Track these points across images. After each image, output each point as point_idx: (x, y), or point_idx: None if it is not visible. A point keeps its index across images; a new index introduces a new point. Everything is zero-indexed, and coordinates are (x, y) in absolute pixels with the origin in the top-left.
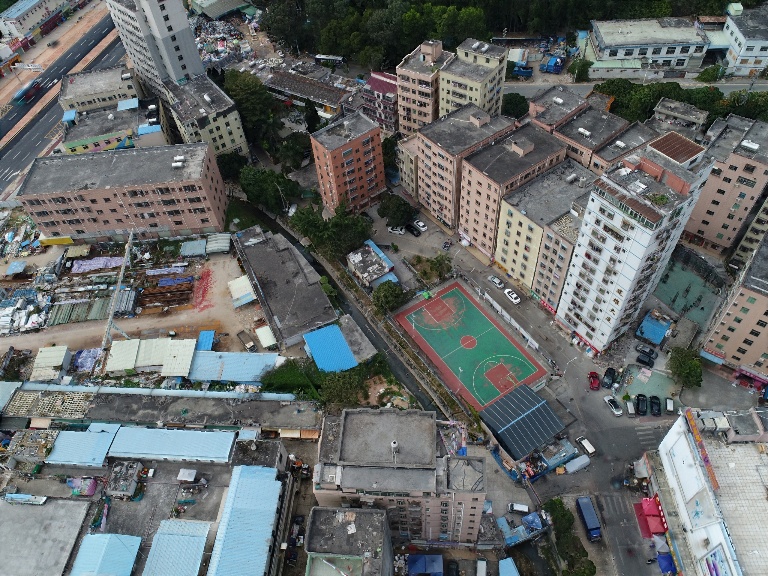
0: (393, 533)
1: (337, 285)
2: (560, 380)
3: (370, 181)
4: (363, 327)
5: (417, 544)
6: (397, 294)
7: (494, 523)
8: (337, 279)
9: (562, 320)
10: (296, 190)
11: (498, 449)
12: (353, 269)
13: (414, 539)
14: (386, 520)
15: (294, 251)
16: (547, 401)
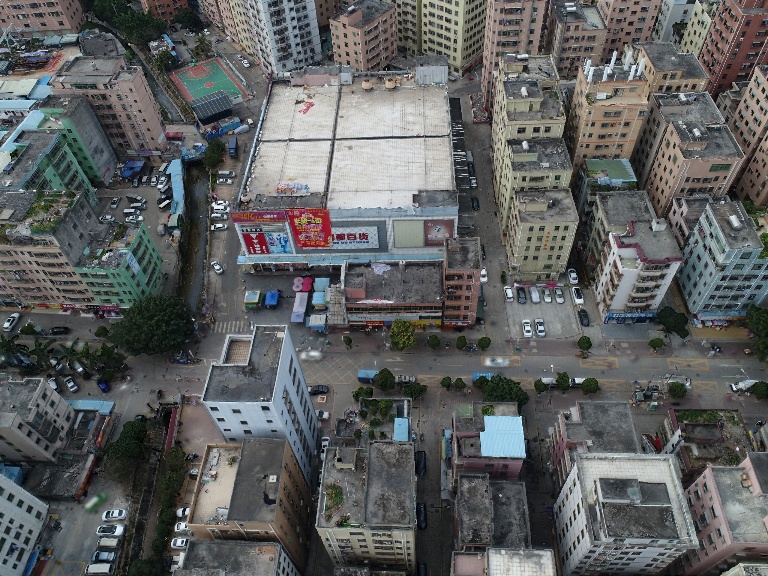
0: (115, 144)
1: (143, 64)
2: (254, 99)
3: (174, 2)
4: (151, 83)
5: (131, 155)
6: (169, 57)
7: (177, 146)
8: (144, 60)
9: (264, 68)
10: (128, 10)
11: (198, 123)
12: (152, 52)
13: (128, 149)
14: (87, 103)
15: (116, 41)
16: (241, 107)
